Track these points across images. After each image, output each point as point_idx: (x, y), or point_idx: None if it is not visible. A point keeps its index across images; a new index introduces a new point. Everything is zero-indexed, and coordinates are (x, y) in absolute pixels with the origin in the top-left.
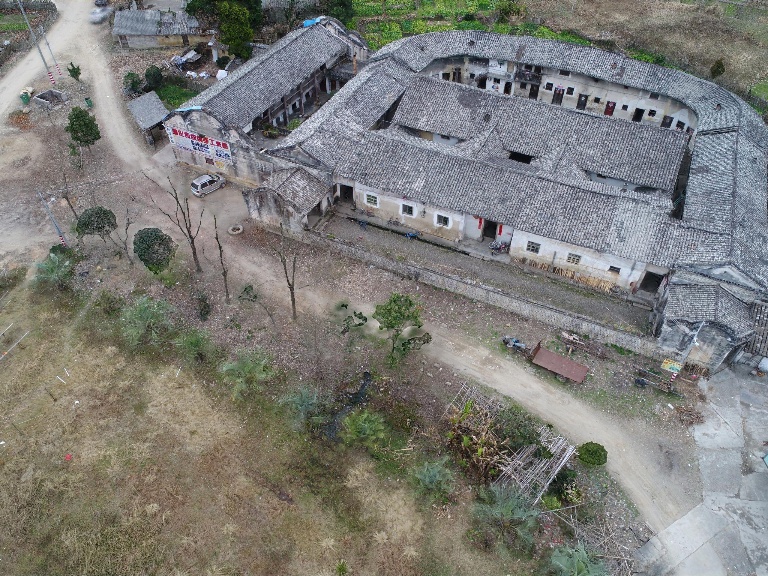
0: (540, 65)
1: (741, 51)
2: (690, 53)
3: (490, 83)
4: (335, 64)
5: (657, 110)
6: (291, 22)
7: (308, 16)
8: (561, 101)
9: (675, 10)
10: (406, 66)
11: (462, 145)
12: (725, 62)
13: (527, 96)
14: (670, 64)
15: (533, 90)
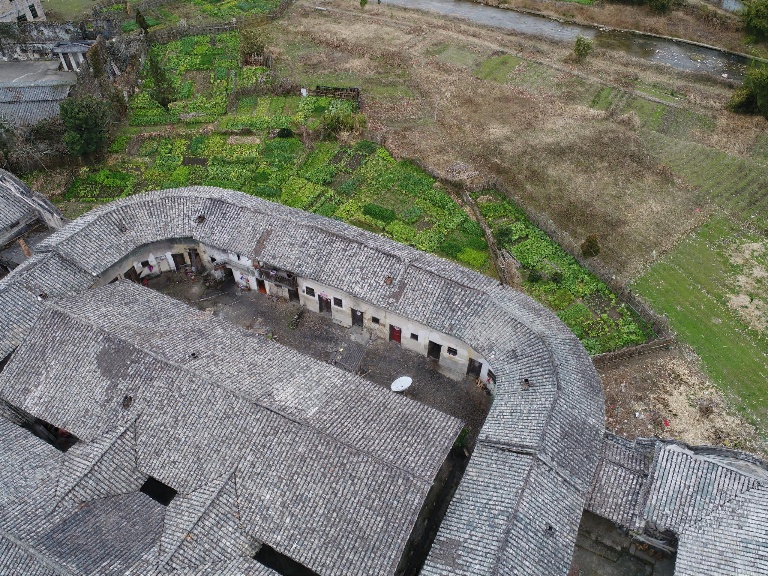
0: (283, 268)
1: (648, 196)
2: (573, 199)
3: (237, 273)
4: (15, 237)
5: (458, 349)
6: (5, 153)
7: (22, 147)
8: (331, 312)
9: (578, 118)
10: (78, 265)
11: (72, 455)
12: (619, 218)
13: (287, 297)
14: (535, 224)
15: (293, 290)
